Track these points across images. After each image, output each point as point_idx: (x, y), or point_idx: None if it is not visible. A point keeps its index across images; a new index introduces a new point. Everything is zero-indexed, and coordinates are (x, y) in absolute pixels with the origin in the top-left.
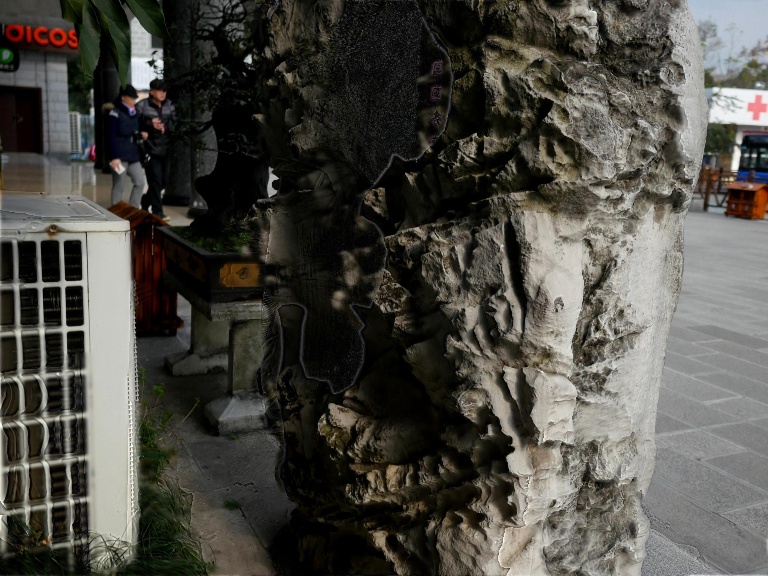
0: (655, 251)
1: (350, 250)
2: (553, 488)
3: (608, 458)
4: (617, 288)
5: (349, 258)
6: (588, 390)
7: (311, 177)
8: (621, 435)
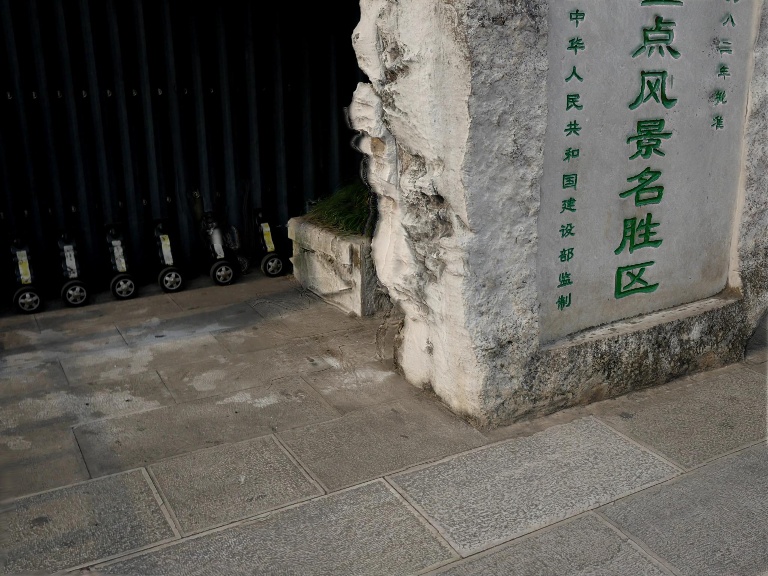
0: (422, 3)
1: None
2: (384, 172)
3: (428, 172)
4: (384, 29)
5: None
6: (390, 105)
7: None
8: (431, 156)
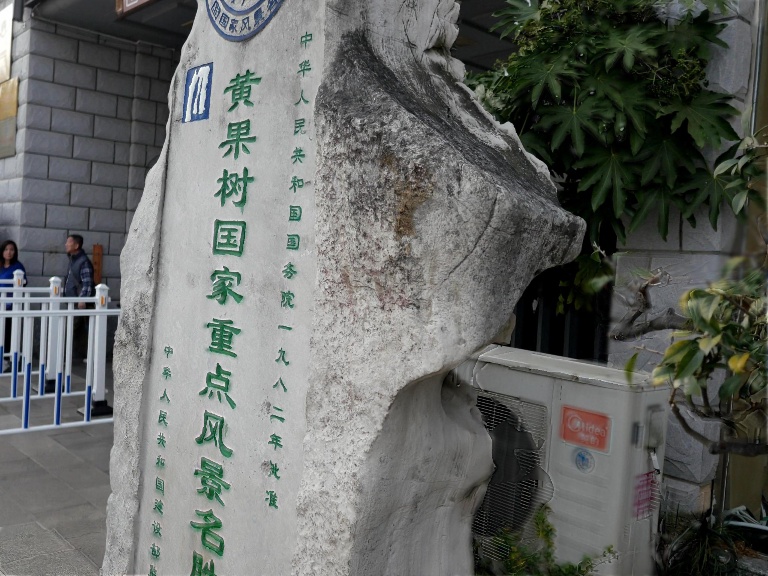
0: None
1: (409, 481)
2: None
3: None
4: None
5: (408, 492)
6: None
7: (463, 369)
8: None
